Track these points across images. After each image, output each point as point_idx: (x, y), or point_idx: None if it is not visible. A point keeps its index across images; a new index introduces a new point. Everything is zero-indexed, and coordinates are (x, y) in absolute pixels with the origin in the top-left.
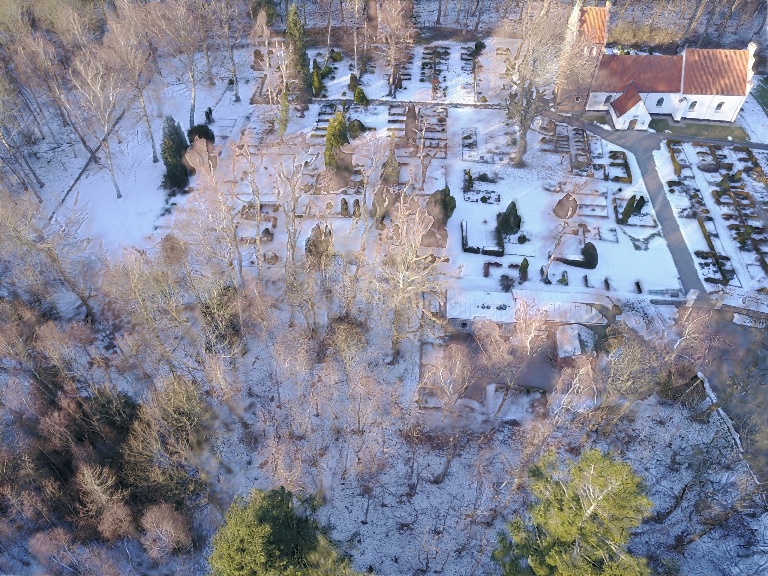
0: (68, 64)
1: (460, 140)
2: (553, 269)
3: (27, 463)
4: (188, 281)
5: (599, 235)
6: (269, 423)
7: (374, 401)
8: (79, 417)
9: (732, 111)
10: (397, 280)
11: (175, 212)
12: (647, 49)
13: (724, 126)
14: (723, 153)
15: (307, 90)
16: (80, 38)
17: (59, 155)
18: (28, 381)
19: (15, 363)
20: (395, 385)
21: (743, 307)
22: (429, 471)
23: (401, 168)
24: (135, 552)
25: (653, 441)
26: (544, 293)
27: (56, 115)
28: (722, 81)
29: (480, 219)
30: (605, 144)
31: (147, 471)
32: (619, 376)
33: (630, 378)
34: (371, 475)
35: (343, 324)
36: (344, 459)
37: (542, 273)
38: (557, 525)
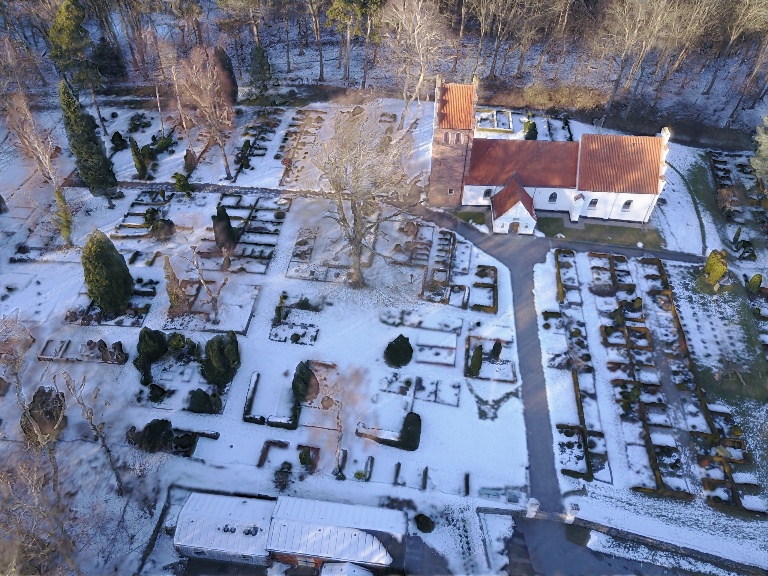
0: None
1: (292, 246)
2: (358, 451)
3: None
4: None
5: (435, 395)
6: None
7: None
8: None
9: (644, 210)
10: None
11: None
12: (566, 115)
13: (634, 228)
14: (627, 267)
15: (104, 180)
16: None
17: None
18: None
19: None
20: None
21: (605, 521)
22: None
23: (203, 288)
24: None
25: None
26: (318, 506)
27: None
28: (628, 175)
29: (281, 369)
30: (475, 254)
31: None
32: None
33: None
34: None
35: None
36: None
37: None
38: None
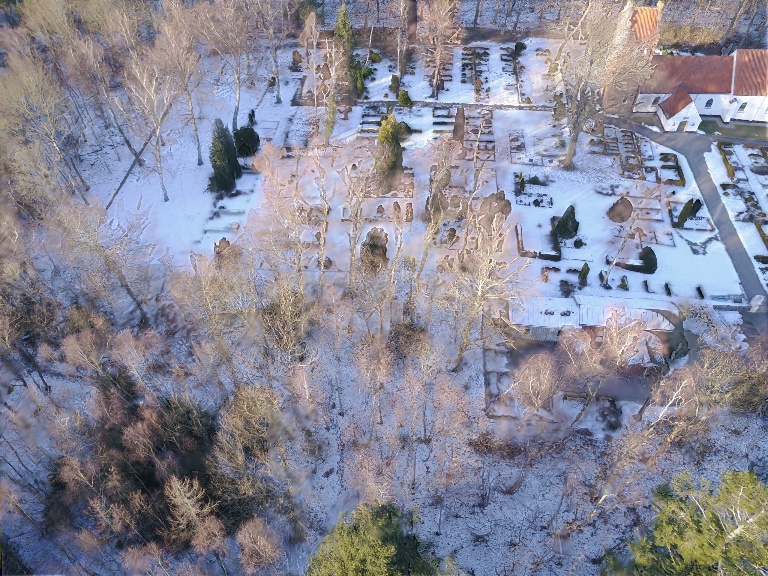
0: (116, 66)
1: (508, 142)
2: (612, 274)
3: (114, 475)
4: (252, 287)
5: (655, 239)
6: (332, 431)
7: (439, 409)
8: (162, 427)
9: None
10: (475, 287)
11: (225, 216)
12: (688, 49)
13: None
14: None
15: (353, 92)
16: (128, 40)
17: (102, 158)
18: (109, 390)
19: (91, 371)
20: (461, 393)
21: None
22: (500, 481)
23: (450, 171)
24: (232, 567)
25: (729, 451)
26: (607, 299)
27: (102, 118)
28: None
29: (534, 223)
30: (655, 146)
31: (236, 483)
32: (718, 388)
33: (729, 390)
34: (441, 485)
35: (407, 330)
36: (412, 468)
37: (601, 278)
38: (694, 547)
